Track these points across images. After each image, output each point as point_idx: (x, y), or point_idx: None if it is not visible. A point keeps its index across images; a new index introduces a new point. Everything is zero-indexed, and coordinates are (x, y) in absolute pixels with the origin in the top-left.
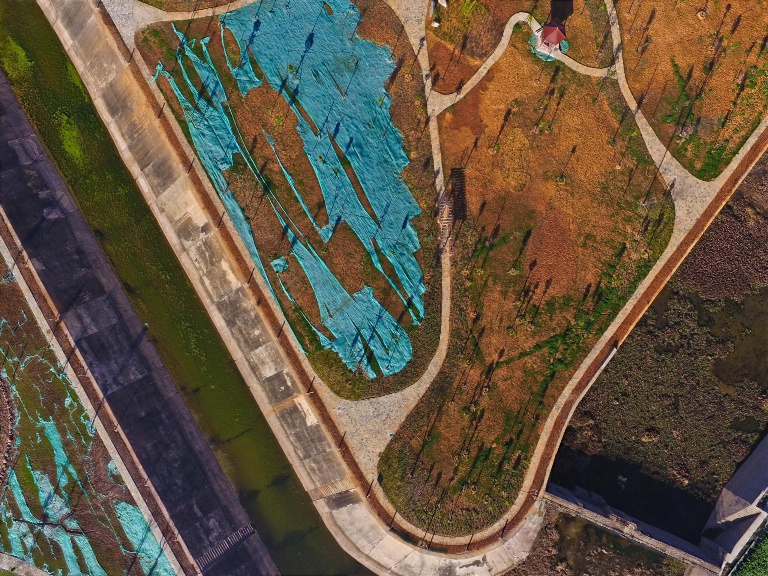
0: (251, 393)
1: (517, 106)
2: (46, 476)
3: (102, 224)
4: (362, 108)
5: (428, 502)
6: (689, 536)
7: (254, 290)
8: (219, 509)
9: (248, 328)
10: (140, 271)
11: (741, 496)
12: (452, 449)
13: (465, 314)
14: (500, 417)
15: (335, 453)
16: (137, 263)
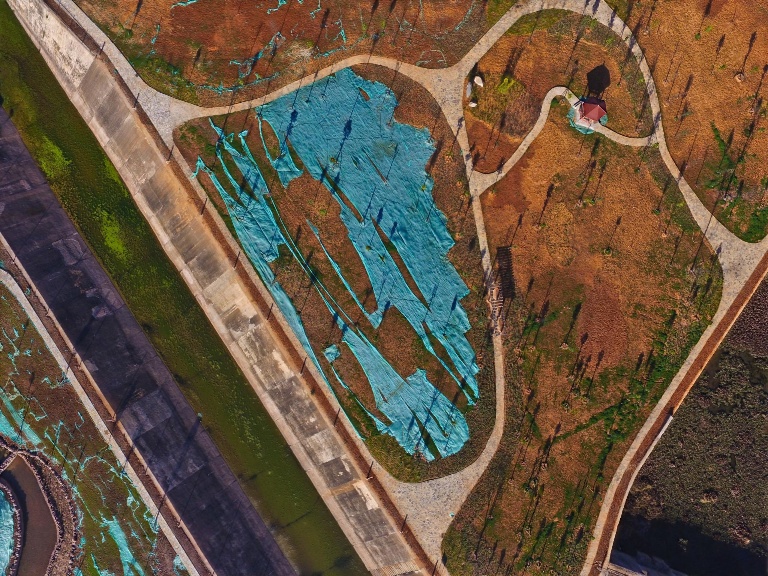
0: (308, 477)
1: (559, 181)
2: (113, 575)
3: (149, 318)
4: (404, 192)
5: None
6: None
7: (307, 379)
8: None
9: (303, 416)
10: (190, 362)
11: None
12: (514, 526)
13: (519, 392)
14: (560, 491)
15: (398, 536)
16: (187, 354)
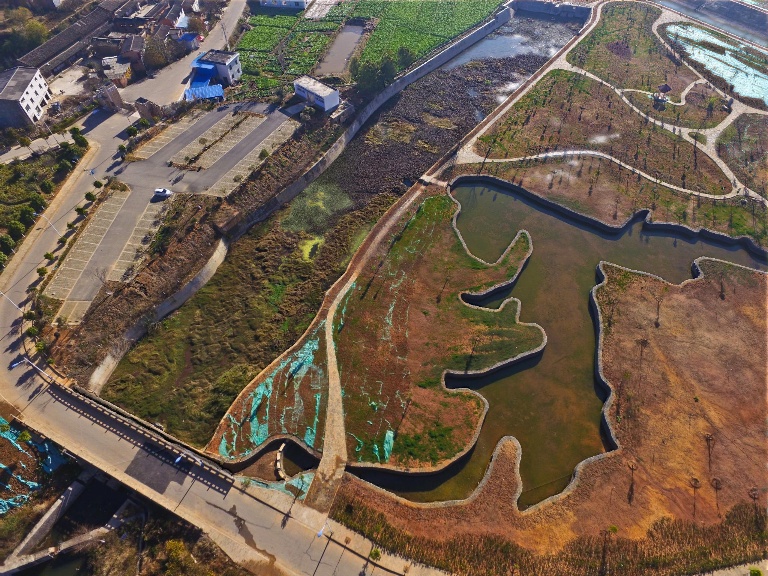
0: None
1: (663, 81)
2: None
3: None
4: None
5: (637, 5)
6: (522, 10)
7: None
8: (715, 10)
9: None
10: None
11: None
12: None
13: (650, 36)
14: None
15: None
16: None
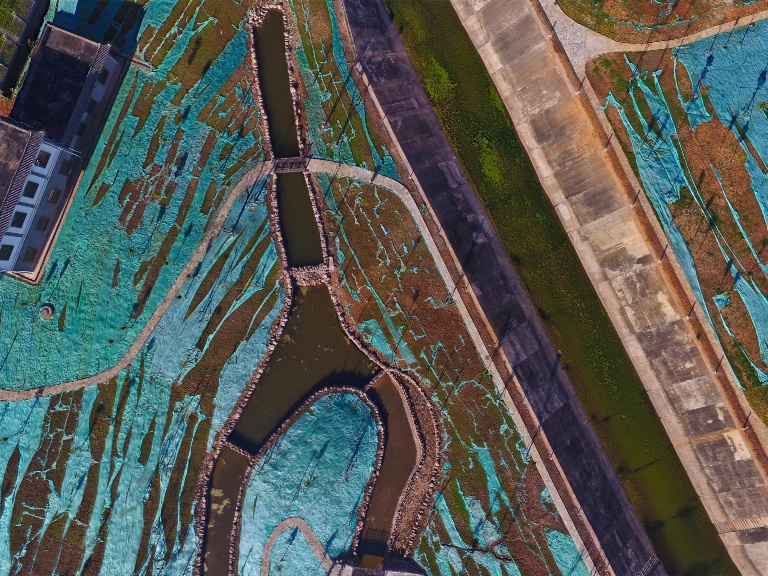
0: (662, 424)
1: None
2: (478, 502)
3: (519, 250)
4: None
5: None
6: None
7: (694, 324)
8: (633, 539)
9: (677, 361)
10: (555, 298)
11: None
12: None
13: None
14: None
15: (767, 489)
16: (553, 290)
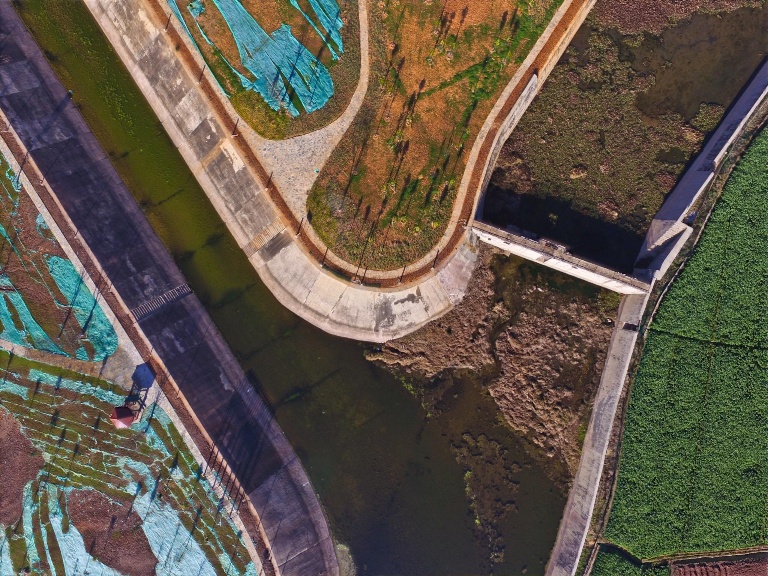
0: (180, 154)
1: None
2: None
3: None
4: None
5: (358, 236)
6: (622, 269)
7: (172, 36)
8: (154, 267)
9: (170, 80)
10: (61, 38)
11: (668, 218)
12: (379, 182)
13: (384, 46)
14: (425, 148)
15: (263, 194)
16: (57, 30)
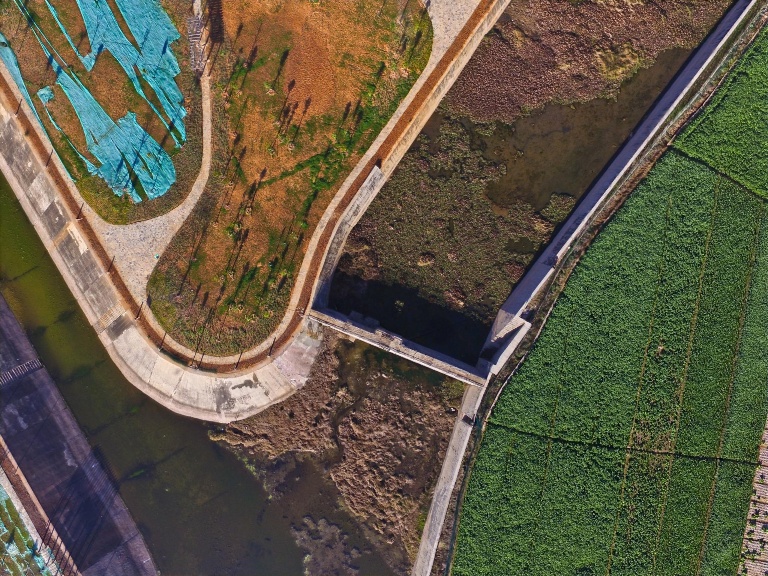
0: (35, 231)
1: None
2: None
3: None
4: None
5: (196, 322)
6: (467, 358)
7: (22, 121)
8: (4, 343)
9: (22, 162)
10: None
11: (510, 311)
12: (218, 269)
13: (225, 135)
14: (264, 237)
15: (105, 277)
16: None
